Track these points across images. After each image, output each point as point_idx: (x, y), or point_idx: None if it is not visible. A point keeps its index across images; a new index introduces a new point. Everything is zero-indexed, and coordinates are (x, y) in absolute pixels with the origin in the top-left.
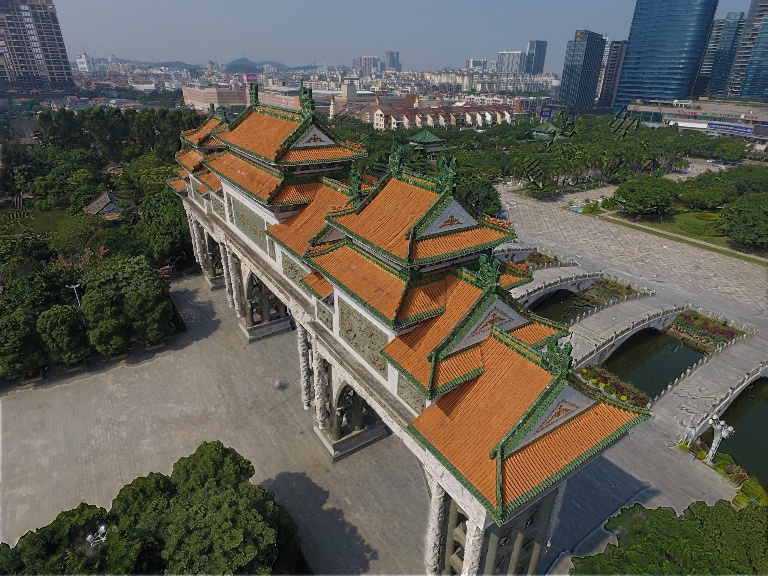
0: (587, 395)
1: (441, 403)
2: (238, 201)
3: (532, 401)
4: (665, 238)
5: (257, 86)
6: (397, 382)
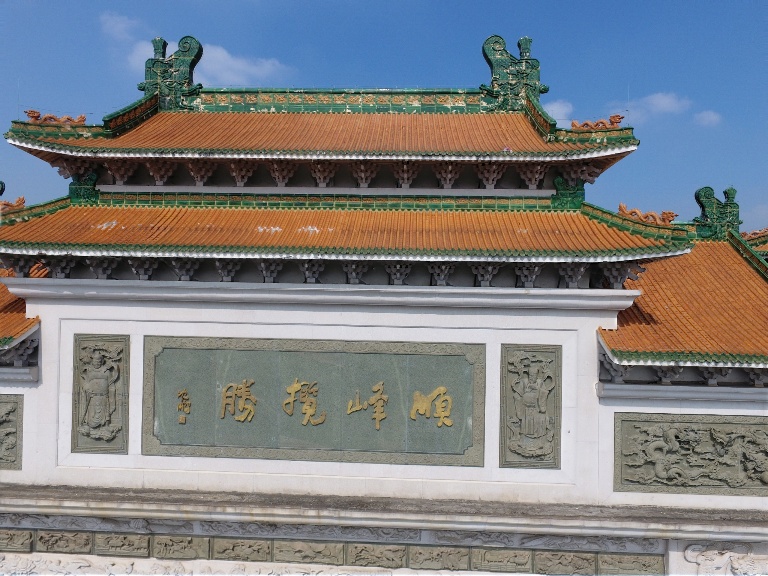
0: None
1: None
2: (222, 340)
3: None
4: None
5: None
6: None
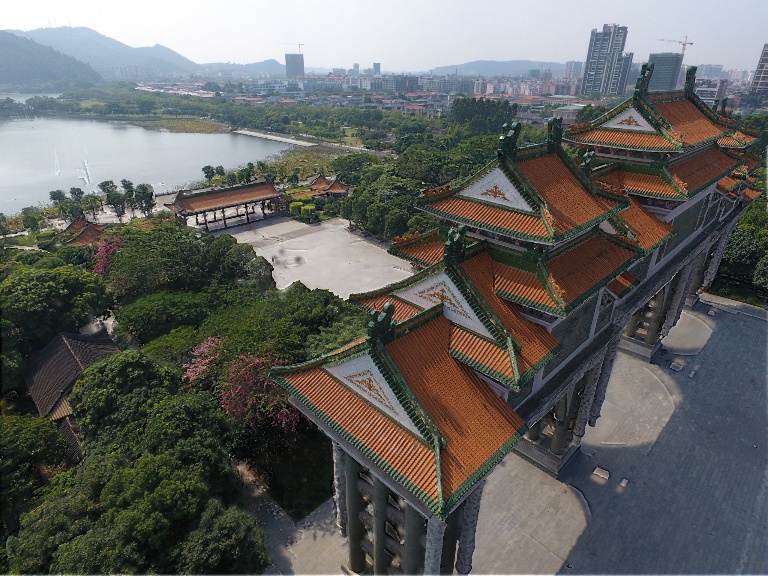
0: (404, 407)
1: None
2: None
3: None
4: None
5: (690, 69)
6: None
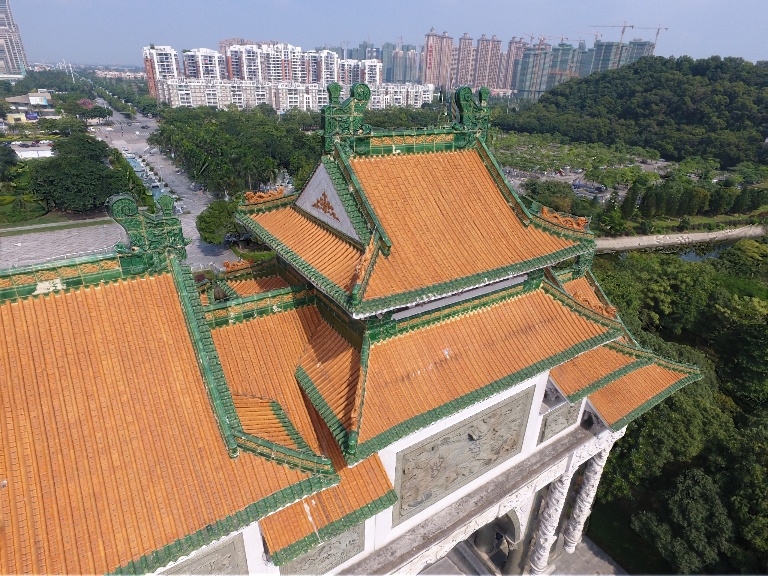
0: None
1: None
2: None
3: None
4: (0, 237)
5: None
6: None
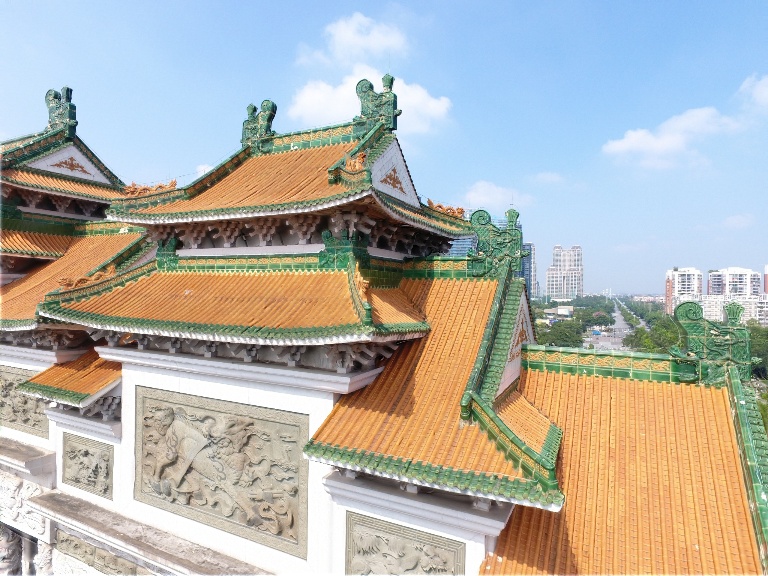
0: None
1: (509, 545)
2: None
3: (724, 449)
4: None
5: None
6: (344, 544)
